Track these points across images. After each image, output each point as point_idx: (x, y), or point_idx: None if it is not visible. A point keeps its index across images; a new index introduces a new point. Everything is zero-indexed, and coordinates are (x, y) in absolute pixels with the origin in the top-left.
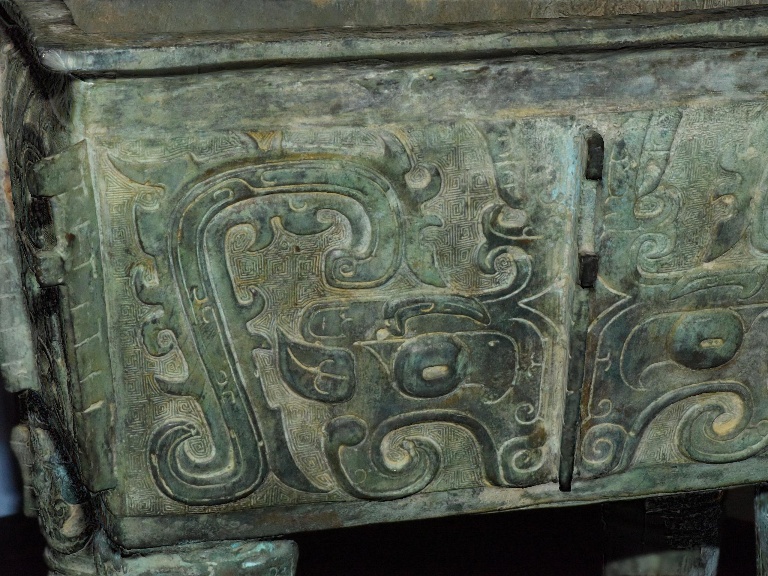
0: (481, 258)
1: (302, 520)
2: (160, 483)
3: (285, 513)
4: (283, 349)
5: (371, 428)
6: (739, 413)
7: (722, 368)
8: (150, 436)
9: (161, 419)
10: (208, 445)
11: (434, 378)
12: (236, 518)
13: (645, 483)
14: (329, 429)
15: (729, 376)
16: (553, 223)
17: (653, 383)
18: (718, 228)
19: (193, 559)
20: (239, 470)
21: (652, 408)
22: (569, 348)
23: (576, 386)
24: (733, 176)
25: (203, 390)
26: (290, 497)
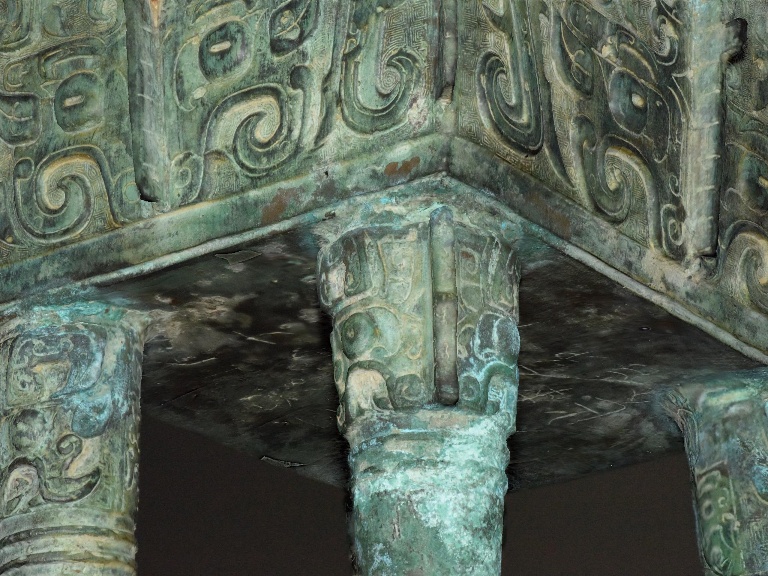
0: (655, 18)
1: (551, 215)
2: (487, 105)
3: (544, 199)
4: (558, 22)
5: (600, 136)
6: (767, 271)
7: (762, 218)
8: (478, 58)
9: (485, 46)
10: (510, 91)
11: (637, 107)
12: (518, 183)
13: (720, 313)
14: (578, 121)
15: (766, 228)
16: (687, 16)
17: (731, 206)
18: (758, 85)
19: (480, 222)
20: (531, 124)
21: (733, 228)
22: (715, 115)
23: (722, 151)
24: (762, 46)
25: (512, 32)
26: (552, 179)
